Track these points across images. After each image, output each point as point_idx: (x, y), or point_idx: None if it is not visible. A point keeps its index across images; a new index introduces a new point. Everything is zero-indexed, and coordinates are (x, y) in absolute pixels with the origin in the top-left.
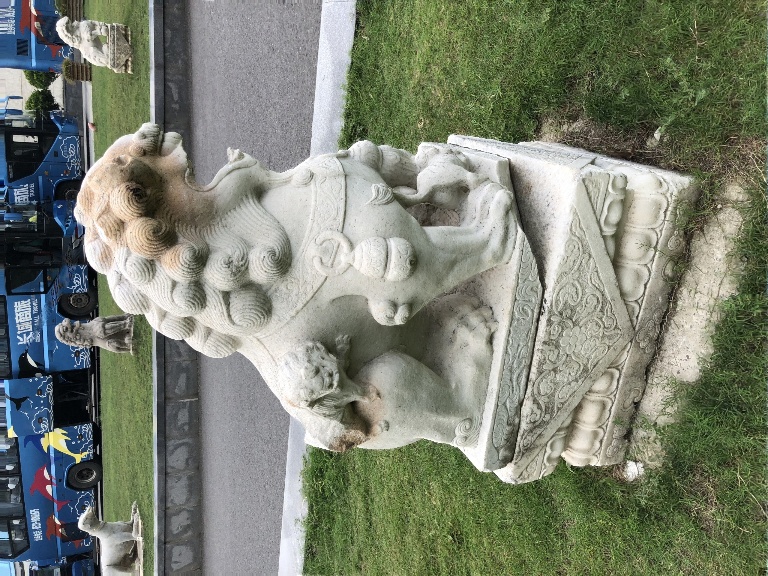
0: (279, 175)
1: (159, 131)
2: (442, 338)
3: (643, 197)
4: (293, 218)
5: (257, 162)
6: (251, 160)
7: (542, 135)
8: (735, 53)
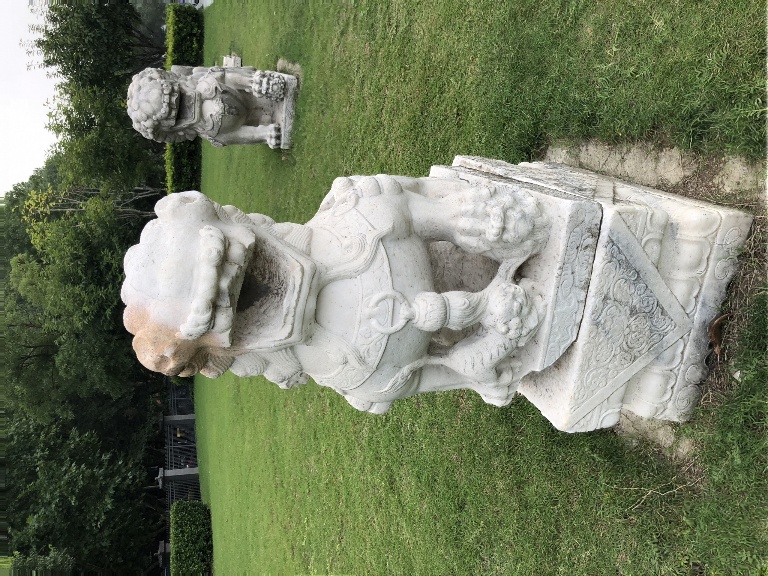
0: (319, 344)
1: (209, 328)
2: None
3: (630, 408)
4: None
5: (302, 339)
6: (296, 340)
7: None
8: (765, 505)
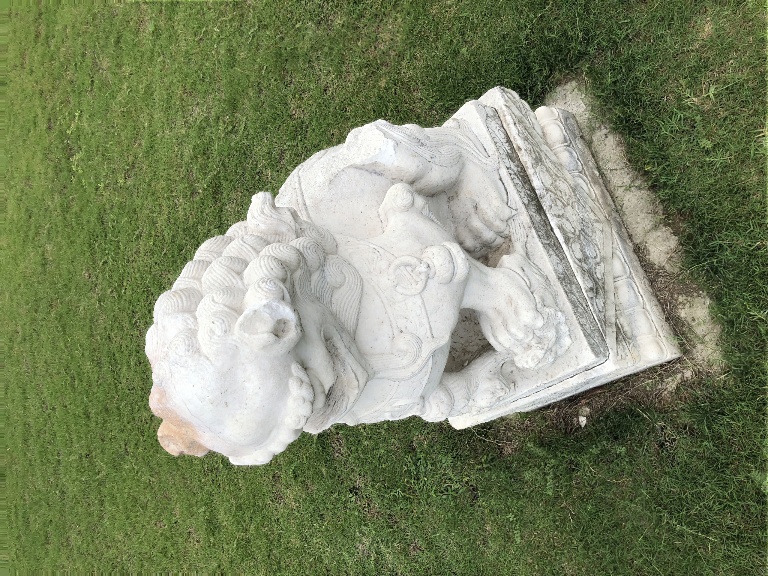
0: None
1: None
2: None
3: None
4: None
5: None
6: None
7: None
8: None
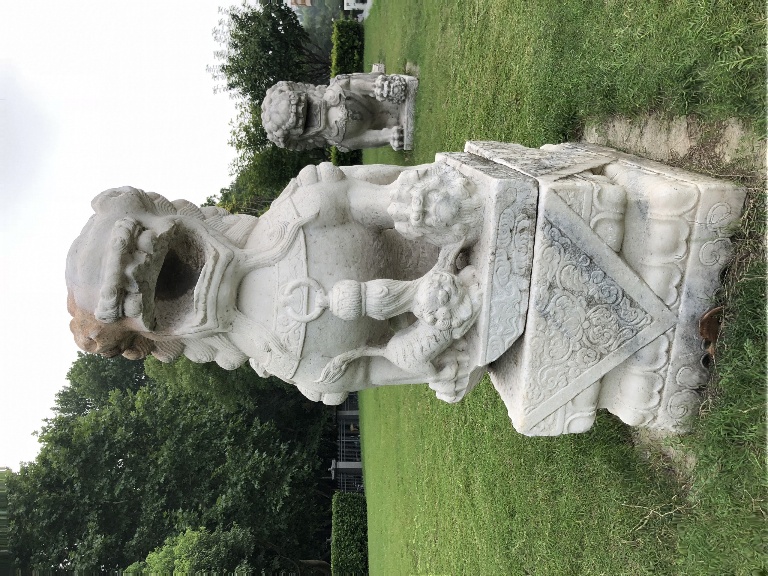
0: (242, 331)
1: (117, 312)
2: (406, 320)
3: None
4: (251, 355)
5: (219, 325)
6: None
7: (767, 144)
8: None
